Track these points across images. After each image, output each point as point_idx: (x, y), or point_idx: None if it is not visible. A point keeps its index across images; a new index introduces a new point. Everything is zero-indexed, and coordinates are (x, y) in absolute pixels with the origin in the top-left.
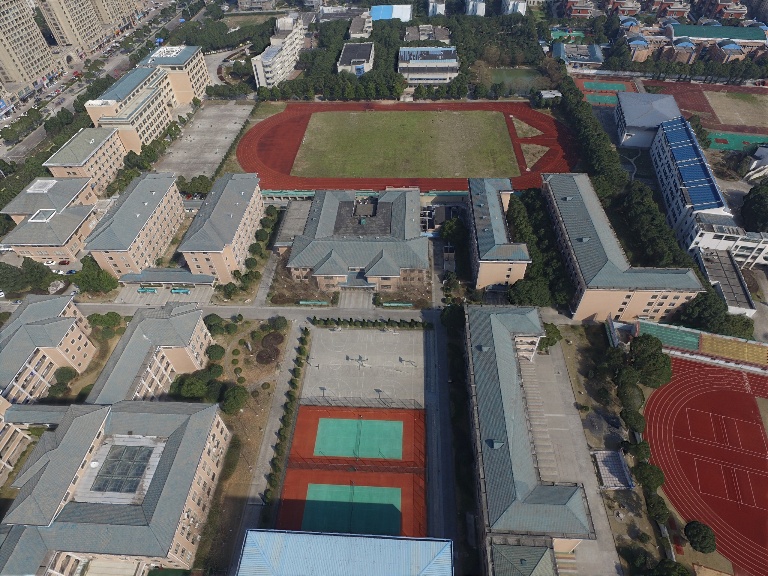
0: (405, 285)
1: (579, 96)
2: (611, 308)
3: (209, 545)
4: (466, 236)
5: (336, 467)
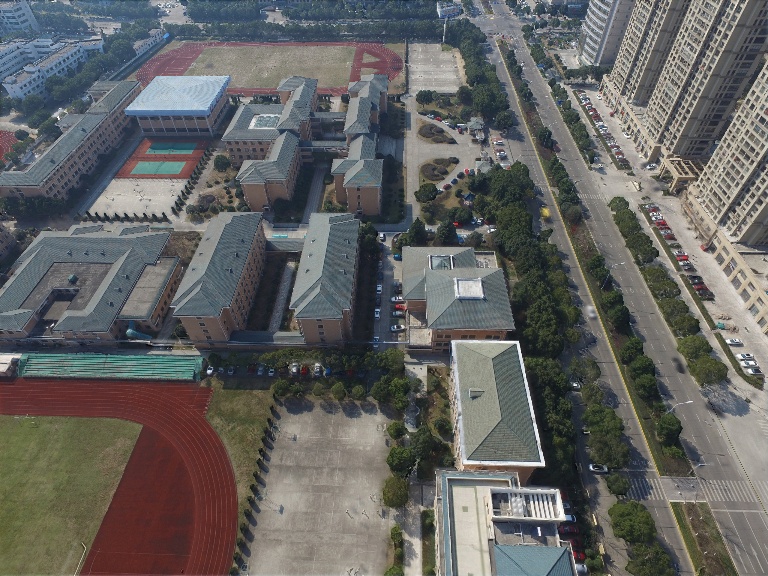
0: None
1: None
2: None
3: None
4: None
5: (175, 158)
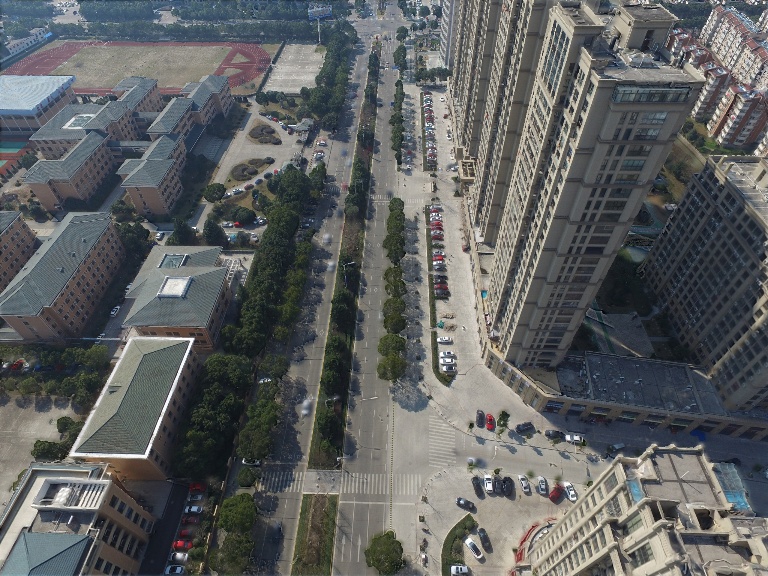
0: None
1: None
2: None
3: None
4: None
5: None
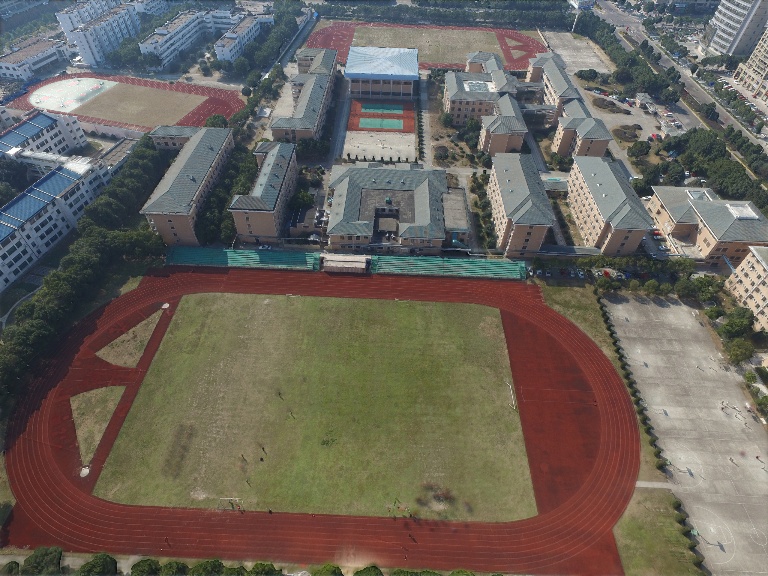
0: None
1: None
2: None
3: None
4: None
5: None
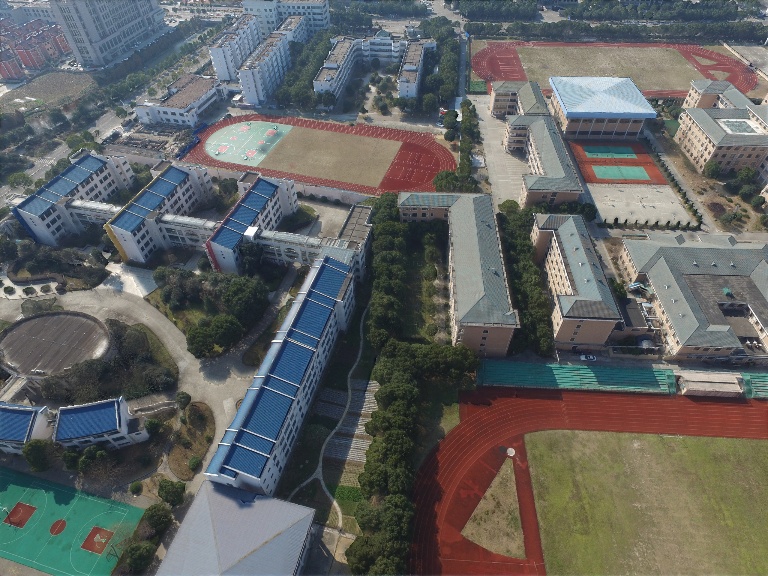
0: None
1: None
2: None
3: None
4: None
5: (627, 163)
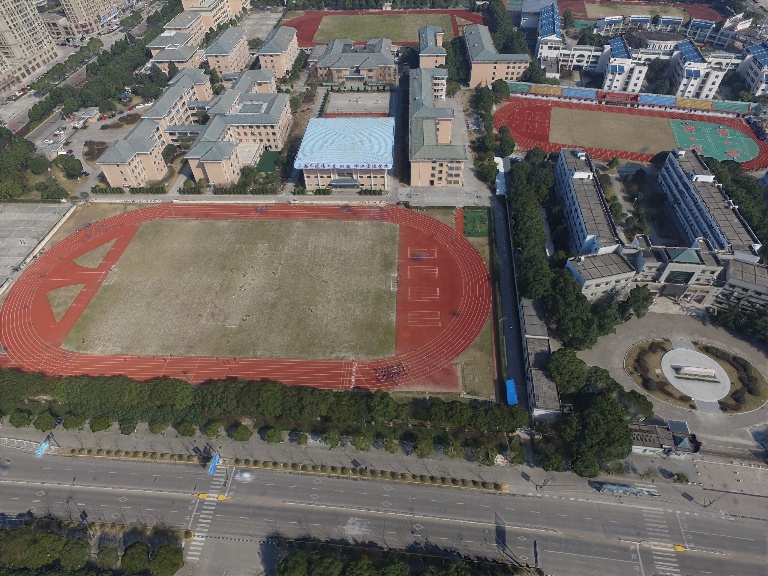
0: (381, 79)
1: (499, 2)
2: (488, 77)
3: (289, 145)
4: (417, 59)
5: None
